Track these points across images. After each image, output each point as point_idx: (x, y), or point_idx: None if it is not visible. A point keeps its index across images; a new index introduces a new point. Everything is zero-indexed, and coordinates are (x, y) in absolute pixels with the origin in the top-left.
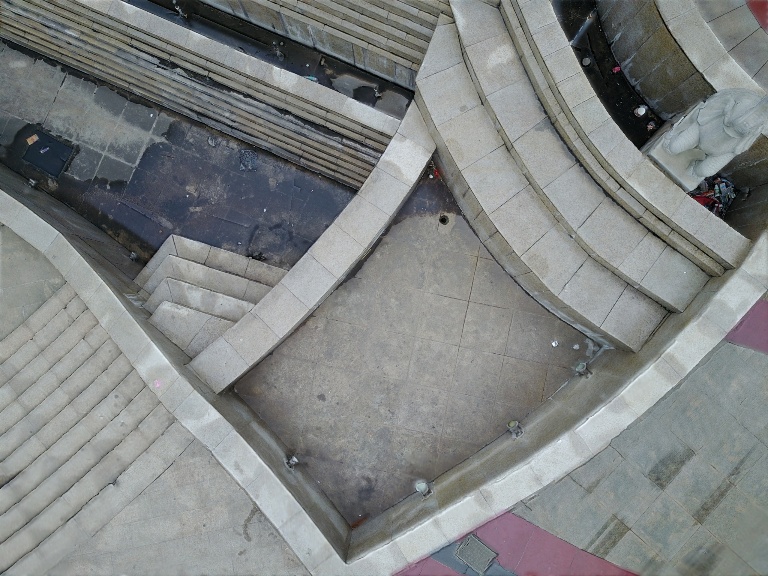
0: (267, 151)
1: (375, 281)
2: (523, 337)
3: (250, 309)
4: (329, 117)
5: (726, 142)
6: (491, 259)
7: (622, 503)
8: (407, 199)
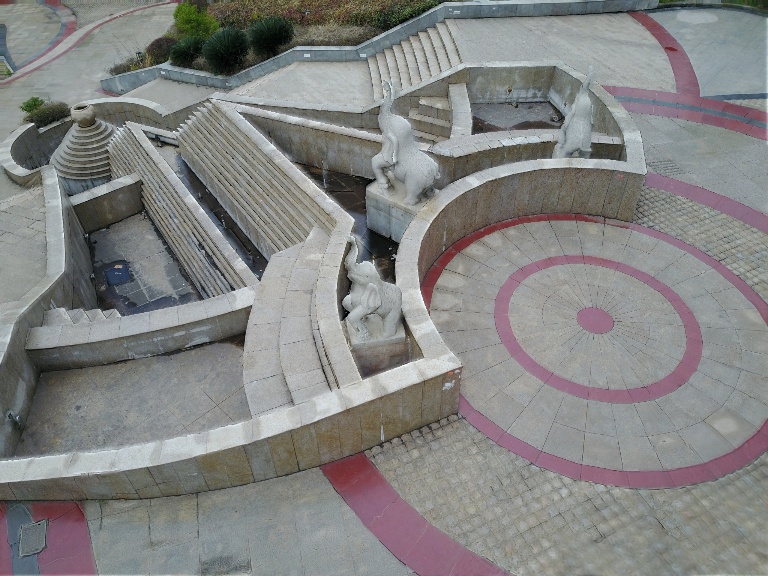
0: None
1: (177, 364)
2: None
3: None
4: None
5: (355, 291)
6: None
7: (165, 570)
8: (237, 334)
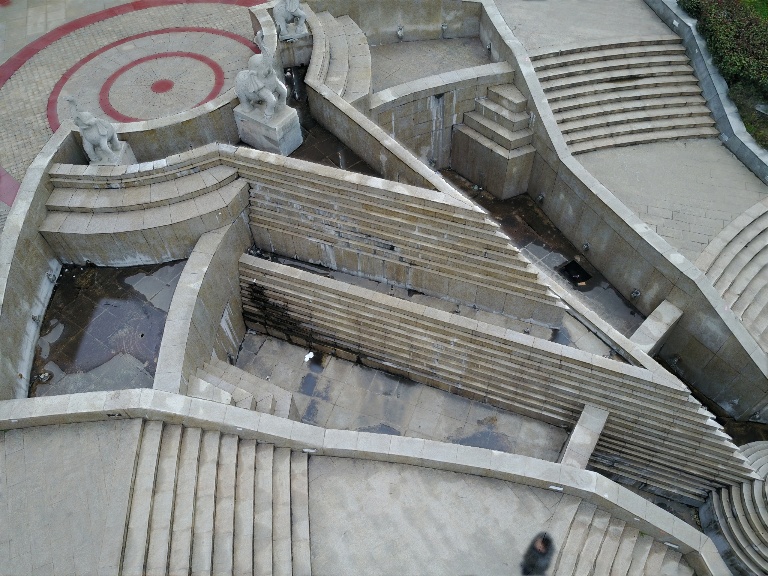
0: None
1: None
2: (378, 60)
3: (482, 102)
4: None
5: None
6: (373, 82)
7: None
8: None
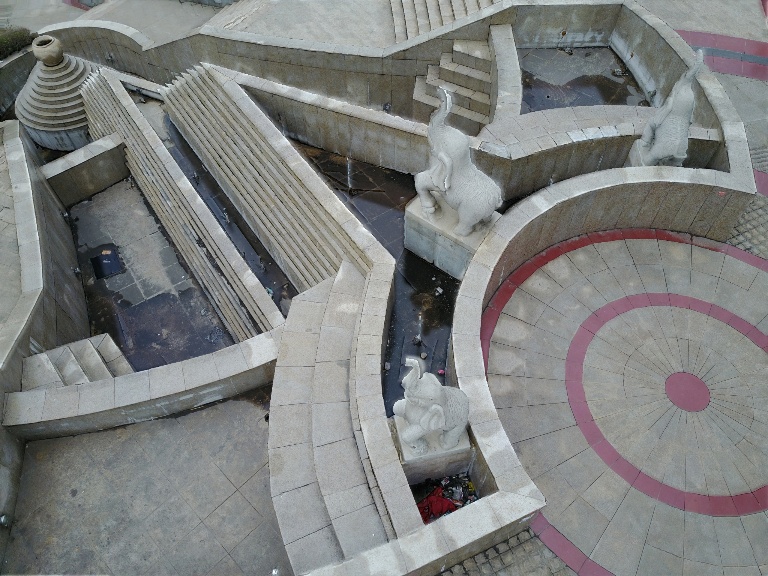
0: (232, 337)
1: (186, 431)
2: (254, 547)
3: None
4: (261, 318)
5: (413, 410)
6: None
7: None
8: (255, 388)
